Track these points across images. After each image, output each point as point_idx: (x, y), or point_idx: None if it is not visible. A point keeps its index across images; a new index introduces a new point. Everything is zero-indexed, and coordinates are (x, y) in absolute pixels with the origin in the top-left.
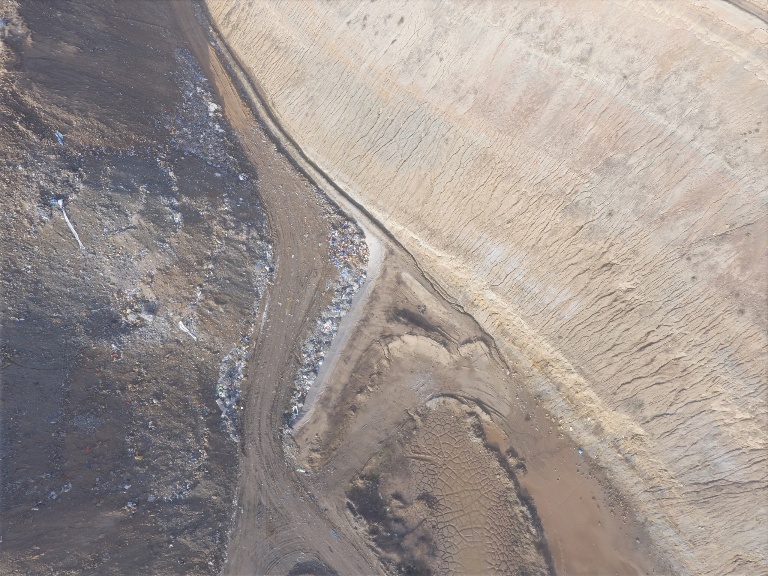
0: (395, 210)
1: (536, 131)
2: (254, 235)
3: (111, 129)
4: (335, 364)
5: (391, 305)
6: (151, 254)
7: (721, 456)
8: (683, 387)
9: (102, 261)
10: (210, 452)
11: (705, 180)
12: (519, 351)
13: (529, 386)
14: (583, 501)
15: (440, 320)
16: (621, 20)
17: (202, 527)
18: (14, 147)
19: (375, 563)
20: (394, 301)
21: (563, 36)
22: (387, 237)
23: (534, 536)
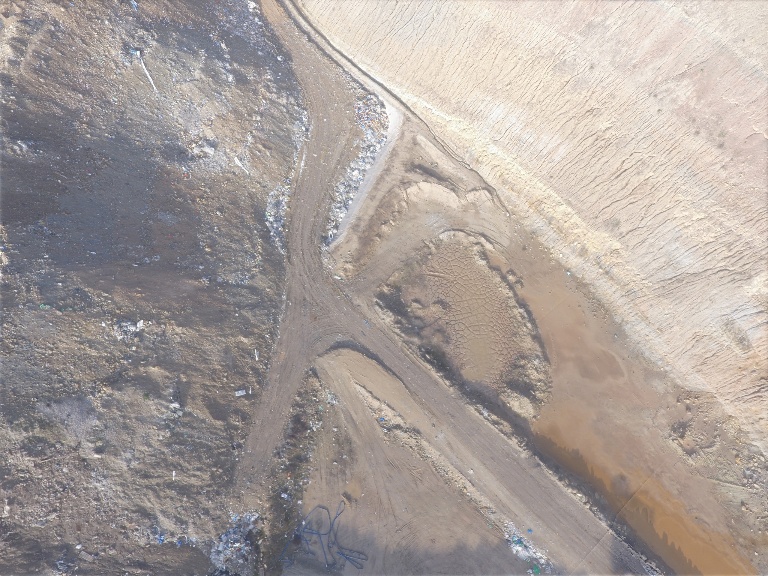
0: (411, 84)
1: (530, 4)
2: (292, 102)
3: (173, 6)
4: (363, 201)
5: (408, 160)
6: (211, 102)
7: (682, 254)
8: (651, 203)
9: (172, 104)
10: (263, 256)
11: (668, 31)
12: (517, 196)
13: (526, 225)
14: (571, 308)
15: (450, 174)
16: None
17: (259, 308)
18: (101, 6)
19: (400, 344)
20: (411, 157)
21: None
22: (404, 107)
23: (530, 330)
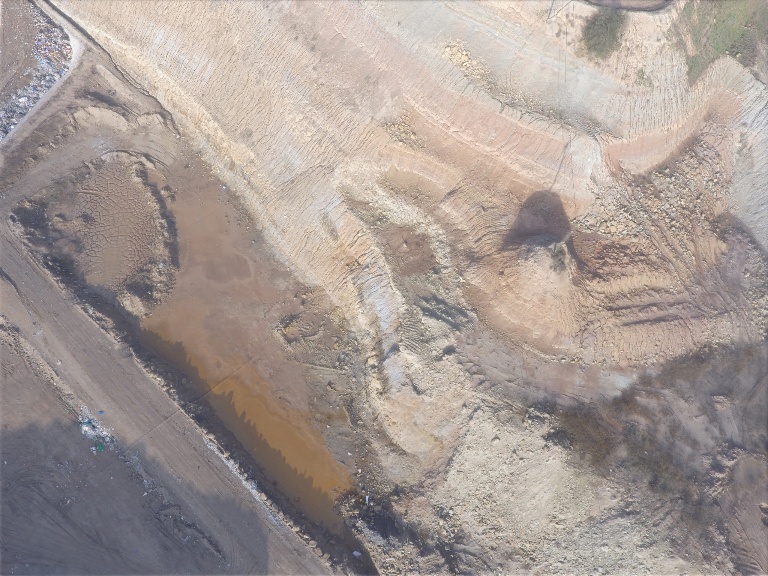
0: (92, 15)
1: None
2: None
3: None
4: (21, 125)
5: (83, 88)
6: None
7: (294, 156)
8: (271, 110)
9: None
10: None
11: None
12: (186, 118)
13: (194, 145)
14: (217, 218)
15: (126, 100)
16: None
17: None
18: None
19: (25, 253)
20: (86, 85)
21: None
22: (86, 38)
23: (166, 238)
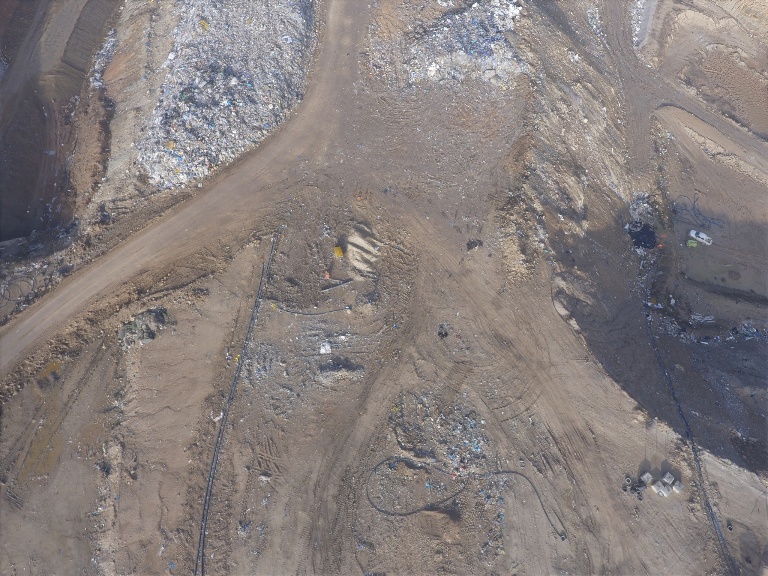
0: None
1: None
2: None
3: None
4: (652, 20)
5: None
6: None
7: None
8: None
9: None
10: None
11: None
12: (758, 22)
13: (766, 43)
14: None
15: (703, 8)
16: None
17: None
18: None
19: (704, 107)
20: None
21: None
22: None
23: None
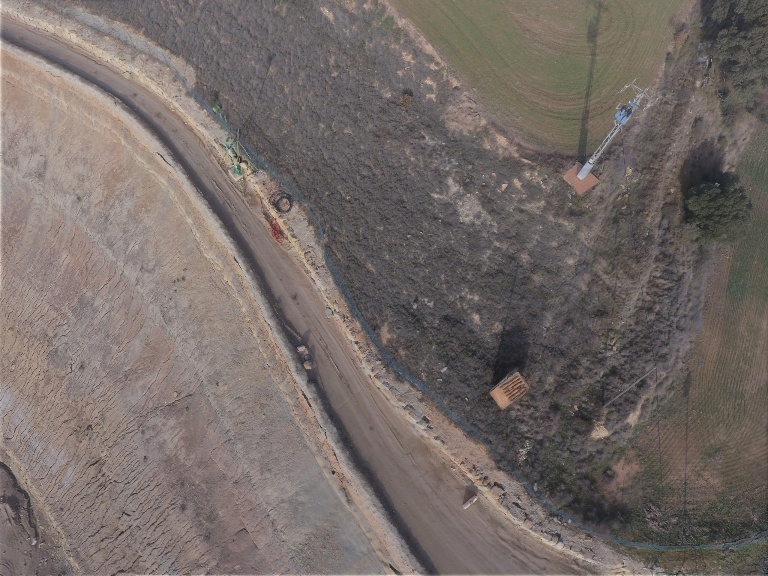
0: None
1: (19, 257)
2: None
3: None
4: None
5: None
6: None
7: None
8: None
9: None
10: None
11: (156, 333)
12: None
13: (56, 559)
14: None
15: None
16: (66, 128)
17: None
18: None
19: None
20: None
21: (18, 145)
22: None
23: None
